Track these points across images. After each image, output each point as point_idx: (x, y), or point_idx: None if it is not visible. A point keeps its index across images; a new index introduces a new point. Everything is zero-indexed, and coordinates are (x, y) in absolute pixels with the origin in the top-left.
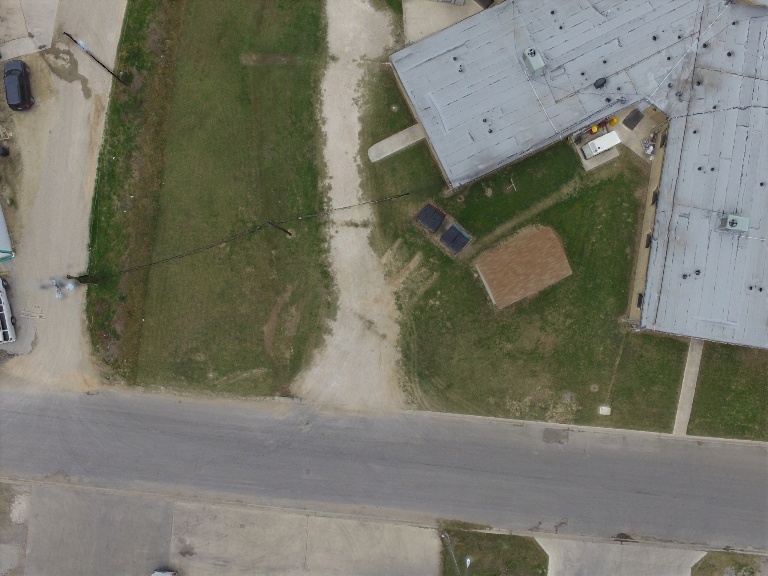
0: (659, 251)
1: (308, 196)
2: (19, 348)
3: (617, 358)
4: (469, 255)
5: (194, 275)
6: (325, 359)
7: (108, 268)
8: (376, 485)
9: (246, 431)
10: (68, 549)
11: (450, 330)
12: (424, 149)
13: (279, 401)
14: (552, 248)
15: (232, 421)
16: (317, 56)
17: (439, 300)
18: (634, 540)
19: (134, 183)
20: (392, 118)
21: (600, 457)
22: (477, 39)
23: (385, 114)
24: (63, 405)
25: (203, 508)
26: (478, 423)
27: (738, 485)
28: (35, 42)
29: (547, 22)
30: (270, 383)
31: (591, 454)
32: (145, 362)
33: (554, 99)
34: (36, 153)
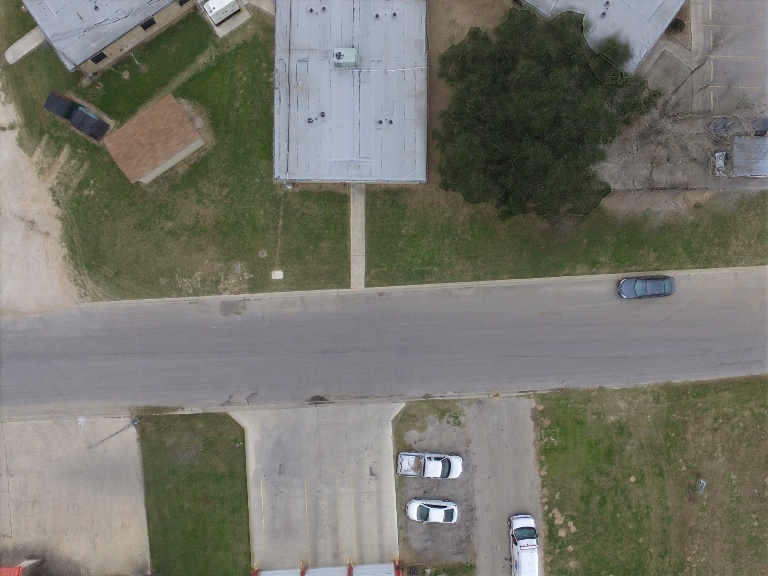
0: (282, 99)
1: None
2: None
3: (279, 220)
4: None
5: None
6: None
7: None
8: (63, 382)
9: None
10: None
11: (109, 217)
12: None
13: None
14: (173, 113)
15: None
16: None
17: (93, 189)
18: (329, 401)
19: None
20: (23, 18)
21: (280, 322)
22: None
23: (16, 15)
24: None
25: None
26: (153, 306)
27: (426, 330)
28: None
29: None
30: None
31: (270, 320)
32: None
33: None
34: None
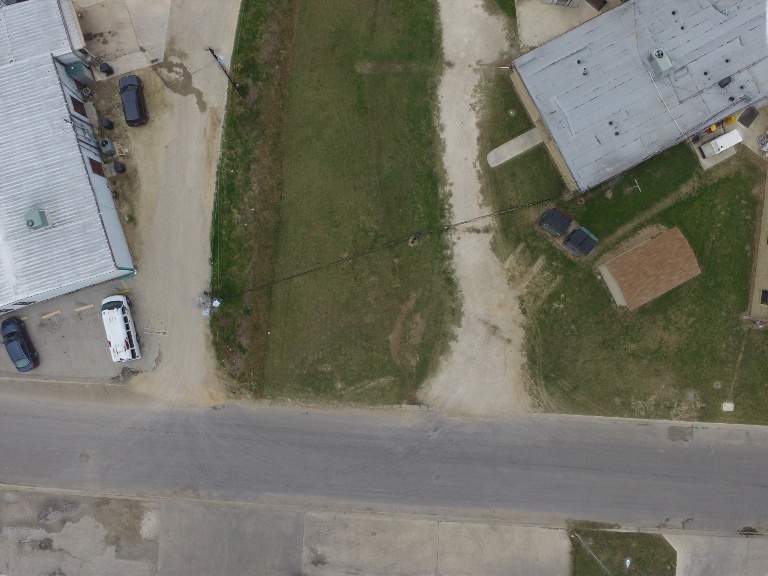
0: None
1: (429, 203)
2: (143, 365)
3: (739, 354)
4: (591, 257)
5: (318, 286)
6: (451, 365)
7: (231, 282)
8: (505, 488)
9: (374, 440)
10: (200, 563)
11: (575, 332)
12: (543, 153)
13: (406, 409)
14: (681, 248)
15: (360, 430)
16: (433, 62)
17: (563, 303)
18: (759, 533)
19: (254, 196)
20: (510, 123)
21: (724, 453)
22: (599, 41)
23: (503, 119)
24: (189, 420)
25: (334, 518)
26: (604, 423)
27: None
28: (147, 56)
29: (668, 22)
30: (397, 391)
31: (715, 450)
32: (271, 375)
33: (678, 99)
34: (153, 169)
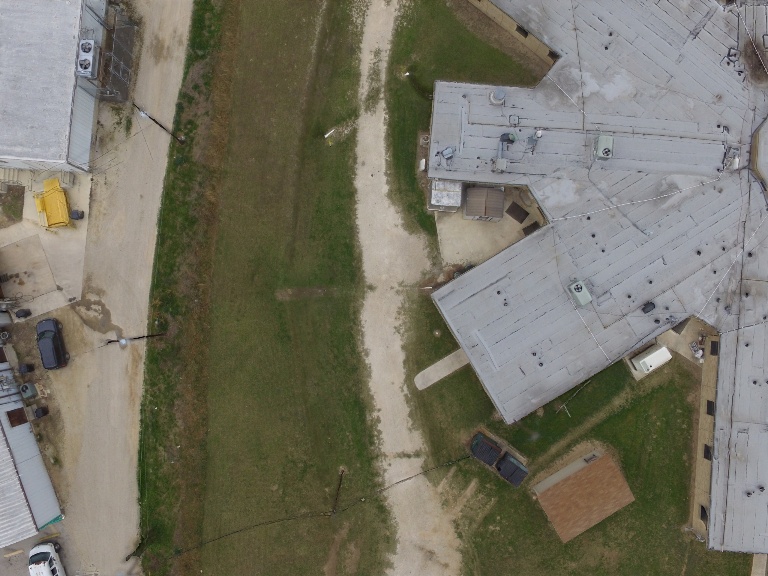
0: (721, 470)
1: (358, 431)
2: None
3: (683, 566)
4: (526, 477)
5: (249, 521)
6: None
7: (161, 522)
8: None
9: None
10: None
11: (513, 554)
12: (471, 373)
13: None
14: (613, 478)
15: None
16: (354, 287)
17: (499, 525)
18: None
19: (179, 433)
20: (436, 344)
21: None
22: (519, 269)
23: (428, 340)
24: None
25: None
26: None
27: None
28: (64, 295)
29: (589, 245)
30: None
31: None
32: None
33: (603, 325)
34: (76, 409)
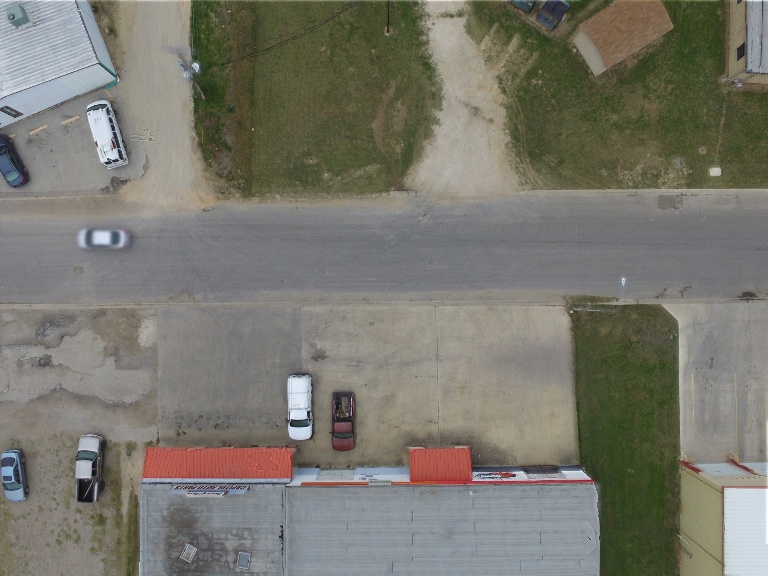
0: None
1: None
2: (131, 173)
3: (721, 118)
4: (565, 32)
5: (298, 81)
6: (435, 149)
7: (213, 82)
8: (499, 268)
9: (365, 229)
10: (200, 366)
11: (555, 107)
12: None
13: (394, 196)
14: (652, 3)
15: (350, 221)
16: None
17: (541, 79)
18: (759, 298)
19: None
20: None
21: (716, 218)
22: None
23: None
24: (180, 224)
25: (330, 310)
26: (593, 197)
27: None
28: None
29: None
30: (384, 178)
31: (707, 216)
32: (258, 171)
33: None
34: None
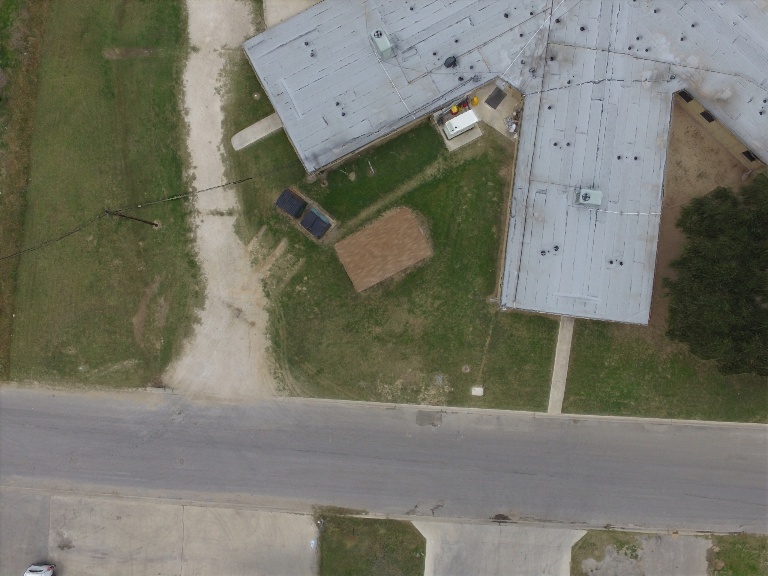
0: (517, 228)
1: (173, 187)
2: None
3: (487, 338)
4: (334, 240)
5: (63, 269)
6: (195, 348)
7: None
8: (250, 473)
9: (119, 423)
10: None
11: (318, 315)
12: None
13: (151, 392)
14: (408, 229)
15: (105, 413)
16: (178, 47)
17: (306, 286)
18: (513, 521)
19: (1, 180)
20: (254, 106)
21: (474, 438)
22: (329, 23)
23: (247, 102)
24: None
25: (79, 501)
26: (350, 408)
27: (616, 462)
28: None
29: (398, 4)
30: (141, 374)
31: (465, 435)
32: (17, 357)
33: (407, 80)
34: None
